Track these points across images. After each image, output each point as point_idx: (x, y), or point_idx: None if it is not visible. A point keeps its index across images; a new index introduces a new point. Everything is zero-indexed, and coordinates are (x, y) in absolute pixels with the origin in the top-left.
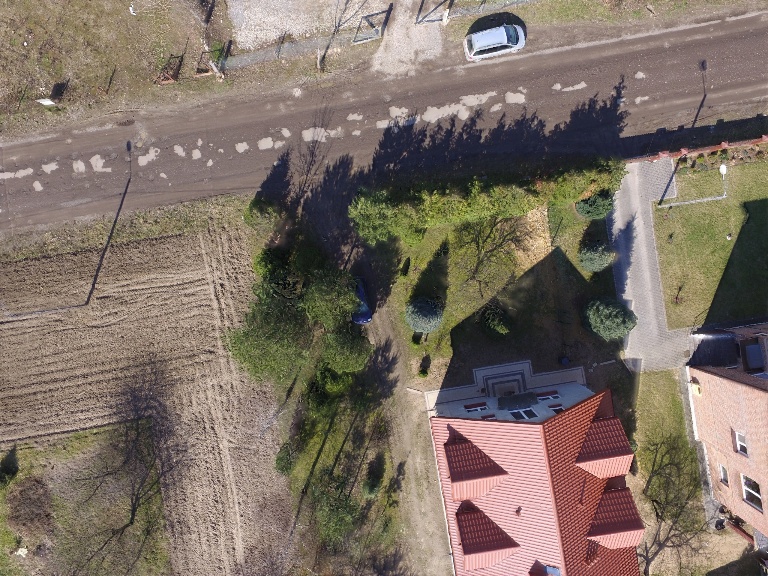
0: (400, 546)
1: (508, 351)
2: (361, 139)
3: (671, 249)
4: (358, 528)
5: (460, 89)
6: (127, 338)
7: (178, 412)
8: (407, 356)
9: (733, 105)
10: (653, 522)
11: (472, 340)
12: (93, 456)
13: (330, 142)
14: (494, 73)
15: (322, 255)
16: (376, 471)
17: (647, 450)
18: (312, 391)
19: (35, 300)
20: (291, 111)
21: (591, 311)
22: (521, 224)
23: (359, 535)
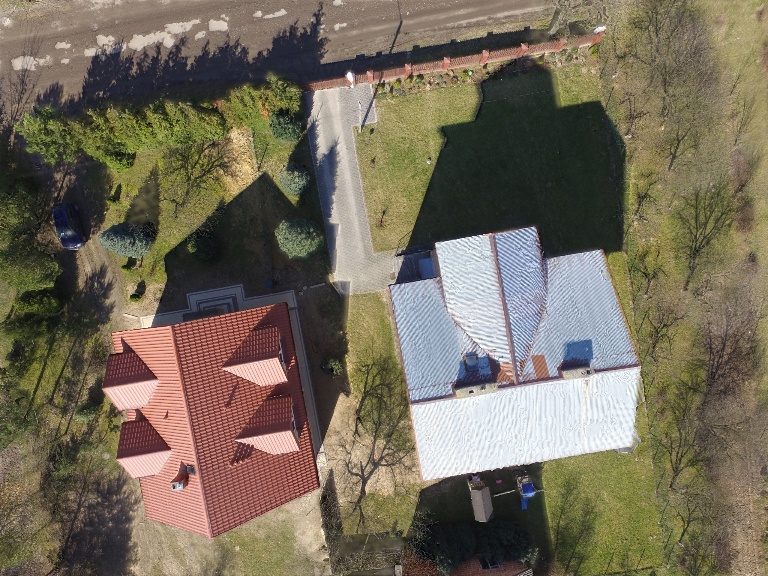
0: (123, 470)
1: (221, 276)
2: (70, 67)
3: (374, 173)
4: None
5: (165, 17)
6: None
7: None
8: (123, 282)
9: (429, 31)
10: (367, 442)
11: (186, 265)
12: None
13: (39, 71)
14: (198, 1)
15: (34, 183)
16: (96, 396)
17: (359, 371)
18: None
19: None
20: (1, 40)
21: (276, 229)
22: (228, 150)
23: (82, 460)
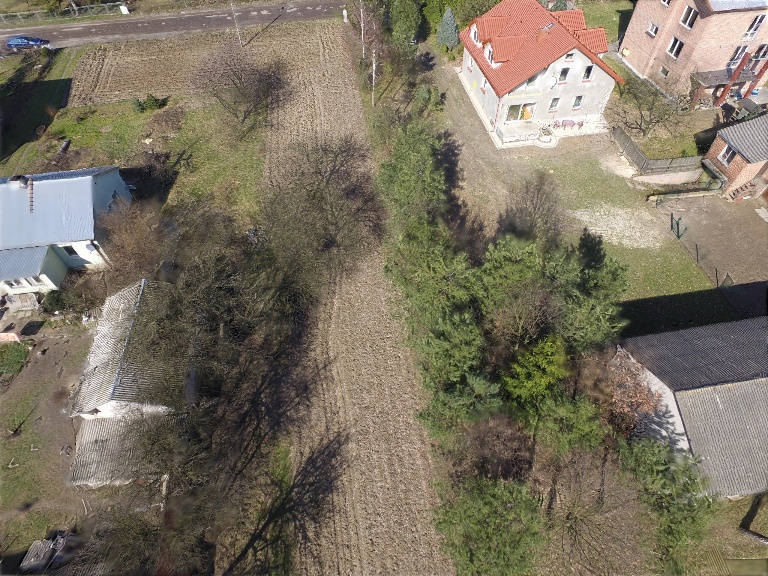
0: (448, 130)
1: None
2: None
3: None
4: (414, 121)
5: None
6: None
7: (288, 81)
8: None
9: None
10: (635, 112)
11: None
12: None
13: None
14: None
15: None
16: None
17: None
18: None
19: (211, 47)
20: None
21: None
22: None
23: None
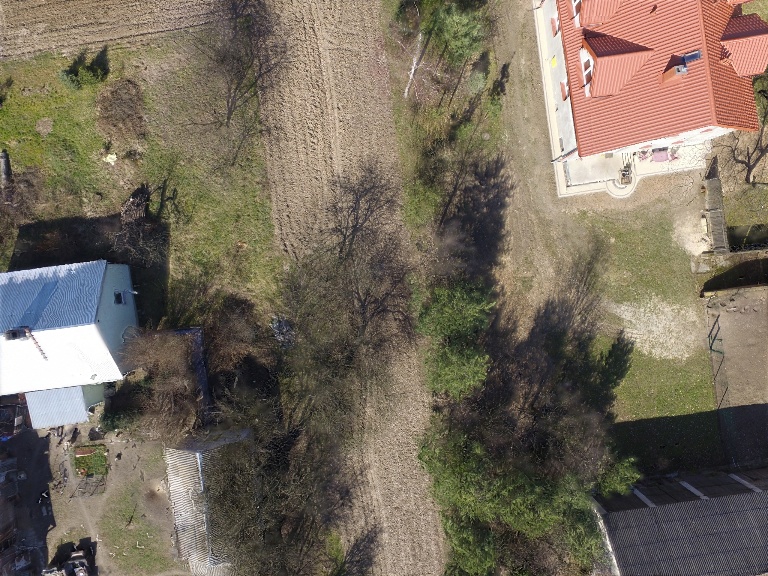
0: (502, 153)
1: None
2: None
3: None
4: None
5: None
6: None
7: (278, 12)
8: None
9: None
10: None
11: None
12: (188, 58)
13: None
14: None
15: None
16: None
17: None
18: None
19: None
20: None
21: None
22: None
23: (461, 139)
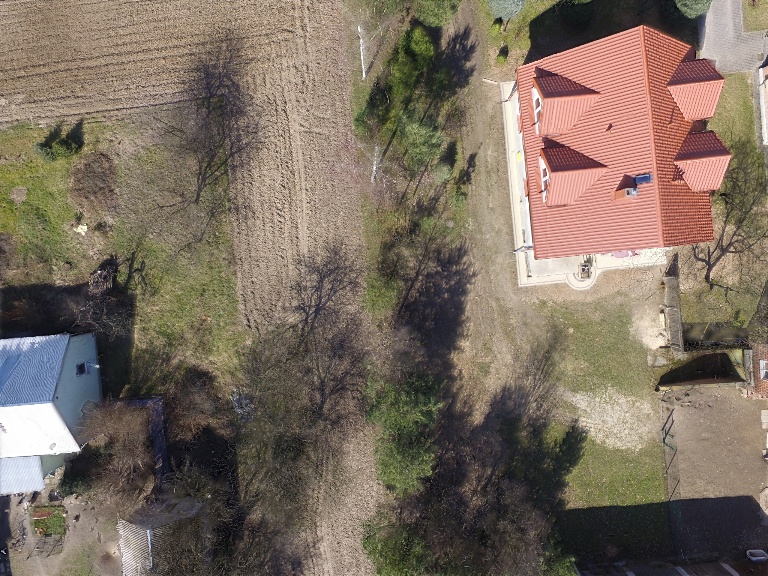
0: (465, 240)
1: None
2: None
3: None
4: None
5: None
6: (204, 13)
7: (251, 93)
8: (485, 46)
9: None
10: (717, 227)
11: (550, 33)
12: (161, 134)
13: None
14: None
15: None
16: (447, 161)
17: None
18: (393, 58)
19: None
20: None
21: None
22: None
23: None
